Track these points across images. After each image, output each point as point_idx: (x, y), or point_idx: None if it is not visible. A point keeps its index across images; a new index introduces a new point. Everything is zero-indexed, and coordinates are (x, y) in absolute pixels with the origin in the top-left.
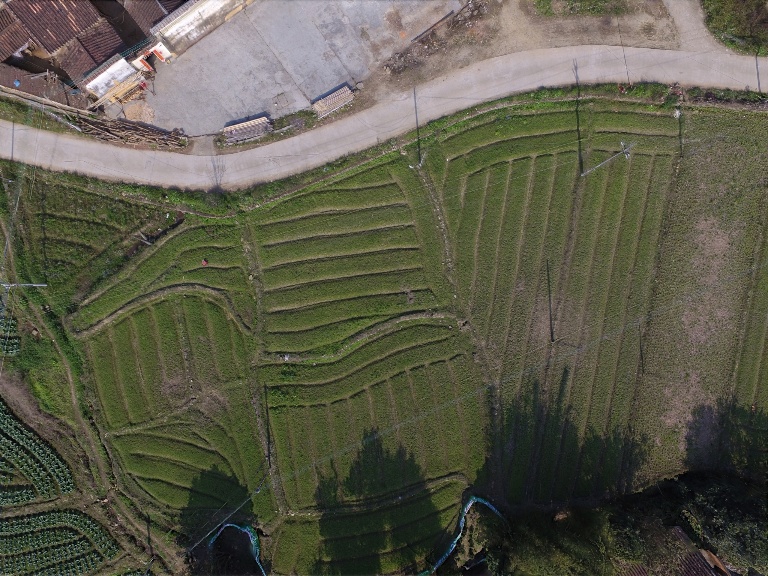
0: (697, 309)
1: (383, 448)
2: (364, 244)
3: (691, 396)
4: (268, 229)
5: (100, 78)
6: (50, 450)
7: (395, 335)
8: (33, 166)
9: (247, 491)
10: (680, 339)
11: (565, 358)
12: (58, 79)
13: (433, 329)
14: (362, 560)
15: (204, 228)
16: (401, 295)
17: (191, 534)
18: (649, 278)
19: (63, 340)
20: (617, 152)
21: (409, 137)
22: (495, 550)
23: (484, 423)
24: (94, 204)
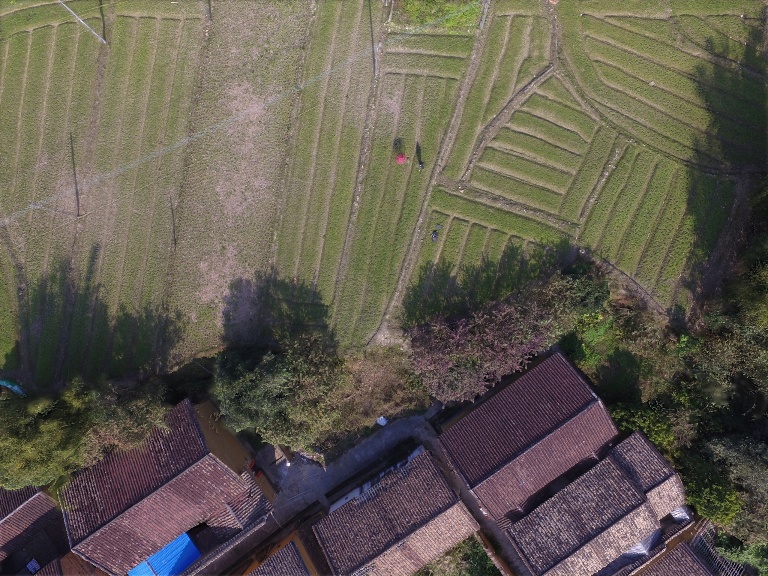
0: (232, 179)
1: None
2: None
3: (228, 270)
4: None
5: None
6: None
7: None
8: None
9: None
10: (215, 210)
11: (92, 234)
12: None
13: None
14: None
15: None
16: None
17: None
18: (181, 148)
19: None
20: (142, 17)
21: None
22: None
23: (14, 305)
24: None
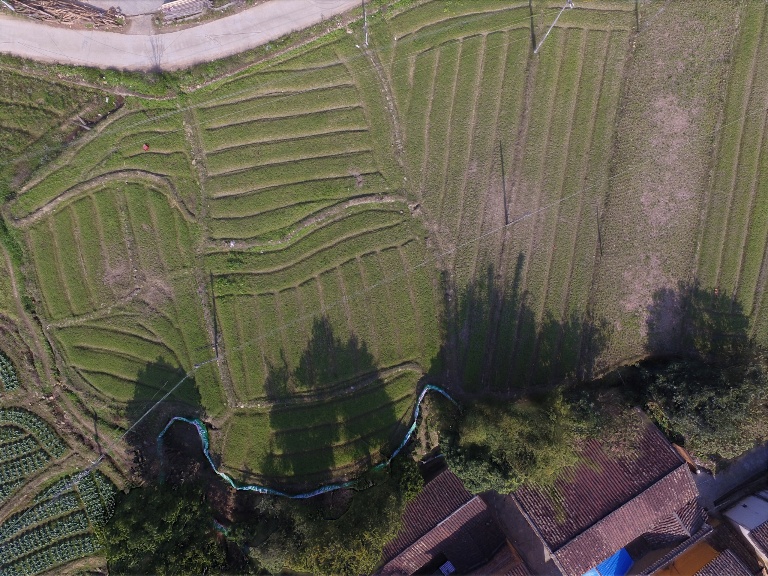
0: (656, 189)
1: (334, 337)
2: (310, 126)
3: (651, 279)
4: (211, 112)
5: None
6: None
7: (344, 221)
8: None
9: (195, 383)
10: (639, 220)
11: (520, 241)
12: None
13: (384, 214)
14: (314, 453)
15: (145, 112)
16: (349, 178)
17: (139, 430)
18: (606, 158)
19: (2, 230)
20: (571, 28)
21: (354, 13)
22: (446, 430)
23: (438, 310)
24: (30, 87)
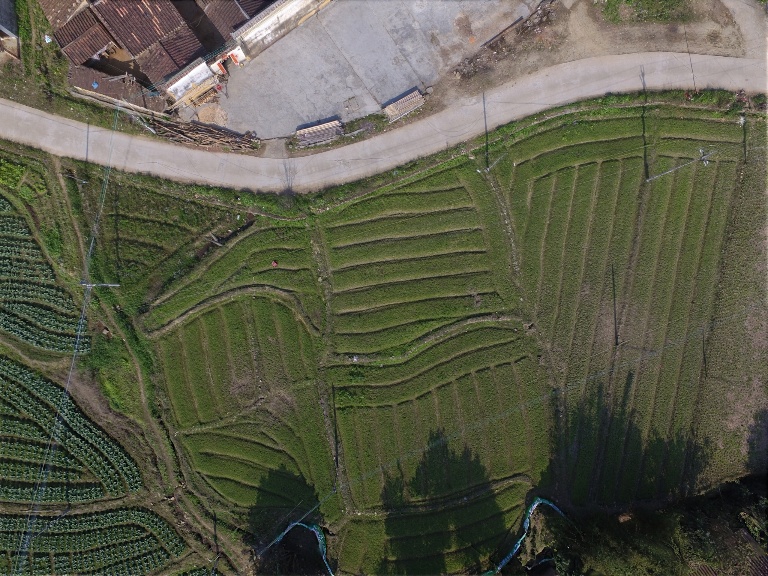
0: (760, 314)
1: (449, 449)
2: (432, 247)
3: (753, 400)
4: (338, 231)
5: (181, 81)
6: (118, 448)
7: (461, 337)
8: (108, 167)
9: (314, 490)
10: (743, 343)
11: (629, 361)
12: (136, 82)
13: (499, 332)
14: (427, 559)
15: (274, 230)
16: (468, 298)
17: (257, 532)
18: (713, 283)
19: (134, 340)
20: (682, 158)
21: (478, 142)
22: (564, 551)
23: (548, 425)
24: (167, 205)
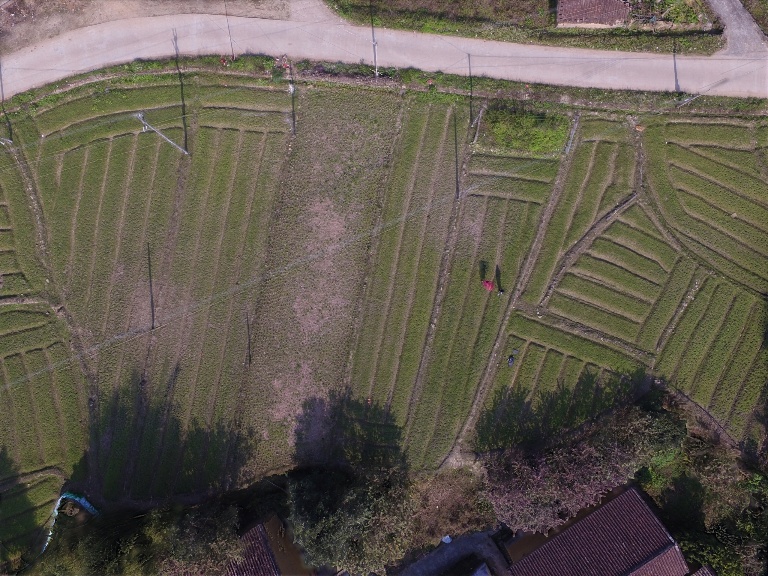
0: (310, 296)
1: None
2: None
3: (302, 388)
4: None
5: None
6: None
7: None
8: None
9: None
10: (291, 327)
11: (166, 347)
12: None
13: (28, 315)
14: None
15: None
16: None
17: None
18: (259, 263)
19: None
20: (225, 129)
21: None
22: None
23: (84, 415)
24: None
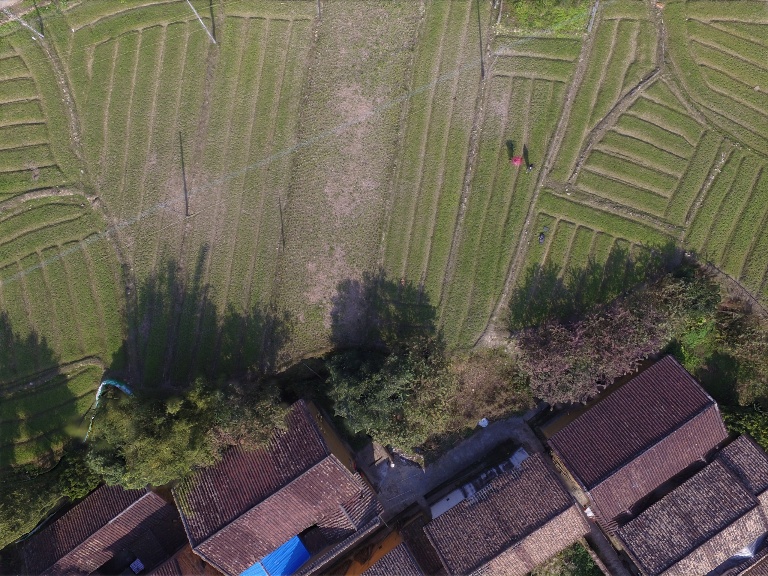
0: (340, 179)
1: (13, 332)
2: None
3: (336, 270)
4: None
5: None
6: None
7: (24, 215)
8: None
9: None
10: (323, 211)
11: (201, 234)
12: None
13: (64, 208)
14: None
15: None
16: (26, 172)
17: None
18: (289, 148)
19: None
20: (252, 18)
21: (25, 5)
22: None
23: (121, 305)
24: None
